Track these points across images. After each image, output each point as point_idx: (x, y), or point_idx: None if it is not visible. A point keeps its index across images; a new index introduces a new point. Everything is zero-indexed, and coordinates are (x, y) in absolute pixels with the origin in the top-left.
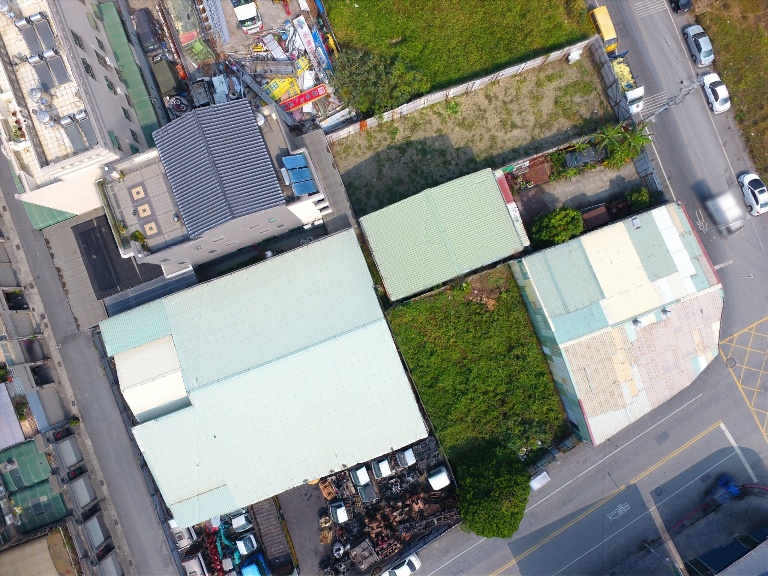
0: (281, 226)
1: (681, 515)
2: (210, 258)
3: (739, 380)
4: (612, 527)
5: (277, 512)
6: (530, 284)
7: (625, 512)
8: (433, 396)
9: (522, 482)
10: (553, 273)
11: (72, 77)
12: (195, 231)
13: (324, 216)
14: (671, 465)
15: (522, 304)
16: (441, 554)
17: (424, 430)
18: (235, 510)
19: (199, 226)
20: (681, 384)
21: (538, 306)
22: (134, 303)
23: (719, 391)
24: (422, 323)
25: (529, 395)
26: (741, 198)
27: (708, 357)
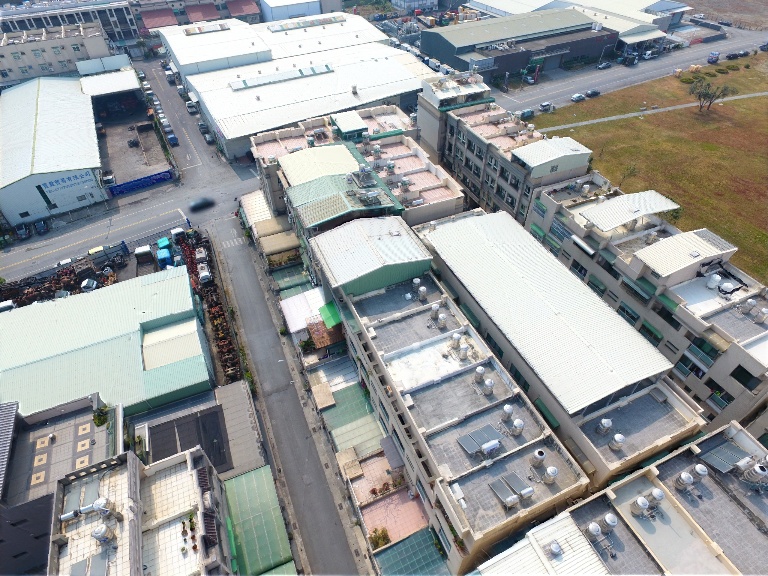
0: None
1: None
2: None
3: None
4: None
5: None
6: None
7: None
8: None
9: None
10: None
11: (69, 572)
12: (8, 406)
13: None
14: None
15: None
16: None
17: None
18: None
19: (0, 410)
20: None
21: None
22: (188, 403)
23: None
24: None
25: None
26: None
27: None
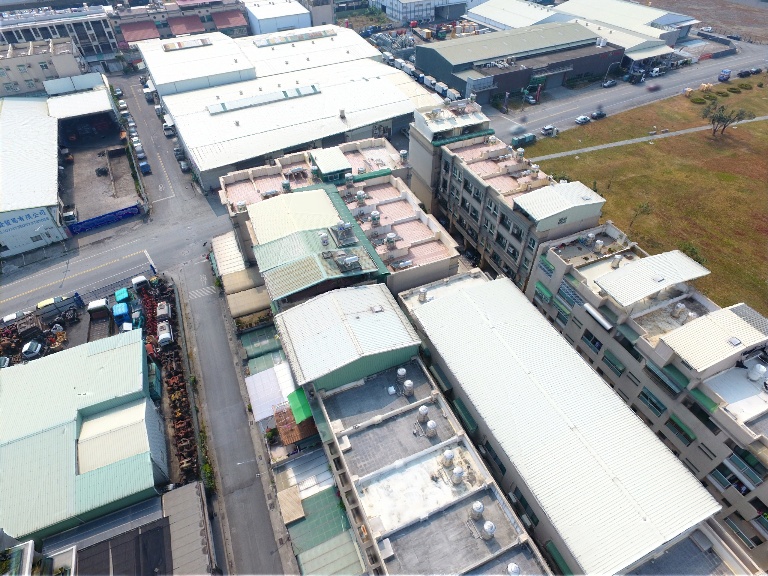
0: None
1: None
2: None
3: None
4: None
5: None
6: None
7: None
8: None
9: None
10: None
11: None
12: None
13: None
14: None
15: None
16: None
17: None
18: None
19: None
20: None
21: None
22: (128, 515)
23: None
24: None
25: None
26: None
27: None
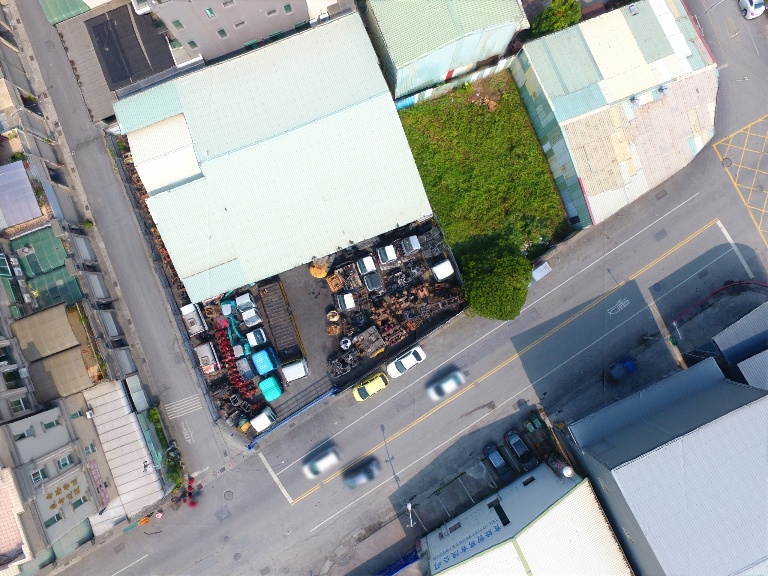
0: (288, 11)
1: (679, 310)
2: (219, 51)
3: (735, 179)
4: (612, 322)
5: (286, 303)
6: (530, 72)
7: (625, 307)
8: (437, 194)
9: (524, 264)
10: (553, 58)
11: None
12: None
13: (330, 9)
14: (669, 261)
15: (523, 106)
16: (446, 349)
17: (428, 207)
18: (245, 302)
19: None
20: (678, 164)
21: (538, 93)
22: None
23: (715, 190)
24: (425, 125)
25: (530, 193)
26: (736, 3)
27: (704, 138)
